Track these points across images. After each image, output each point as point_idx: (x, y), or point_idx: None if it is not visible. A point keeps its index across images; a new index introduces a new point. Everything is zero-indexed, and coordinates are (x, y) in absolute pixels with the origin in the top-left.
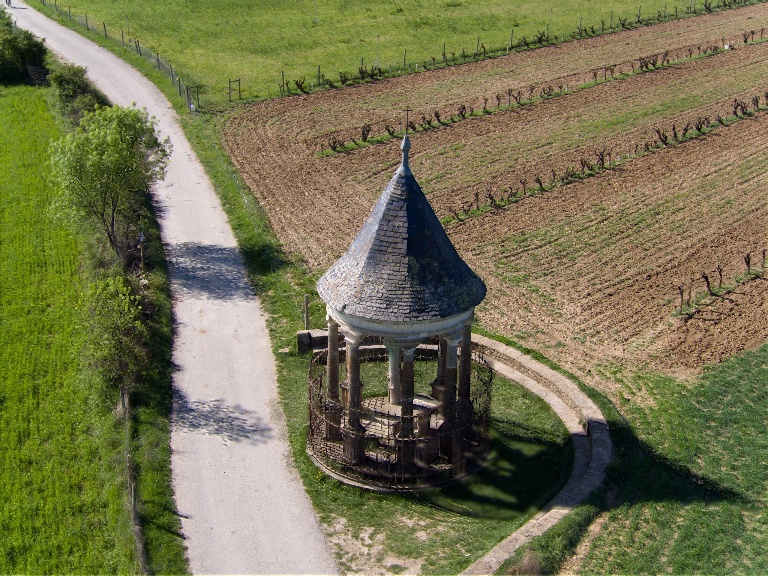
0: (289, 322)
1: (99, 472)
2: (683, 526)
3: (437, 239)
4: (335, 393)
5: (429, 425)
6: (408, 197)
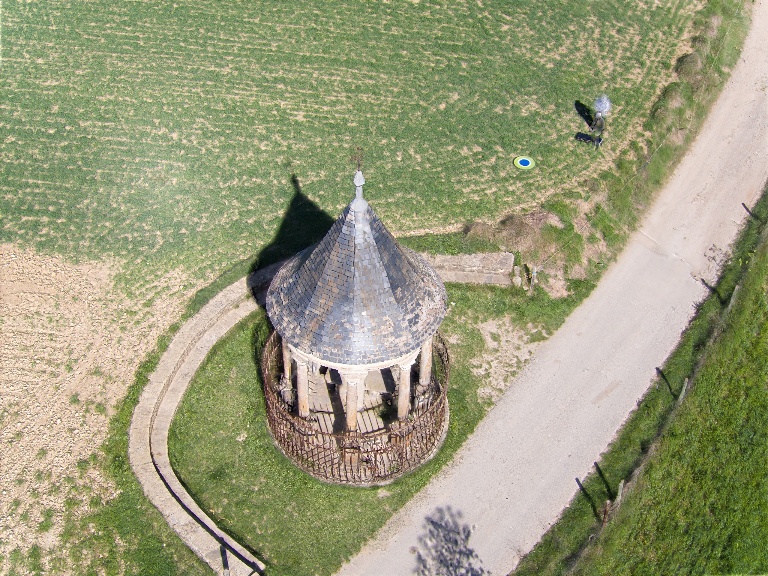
0: None
1: None
2: None
3: None
4: None
5: None
6: None
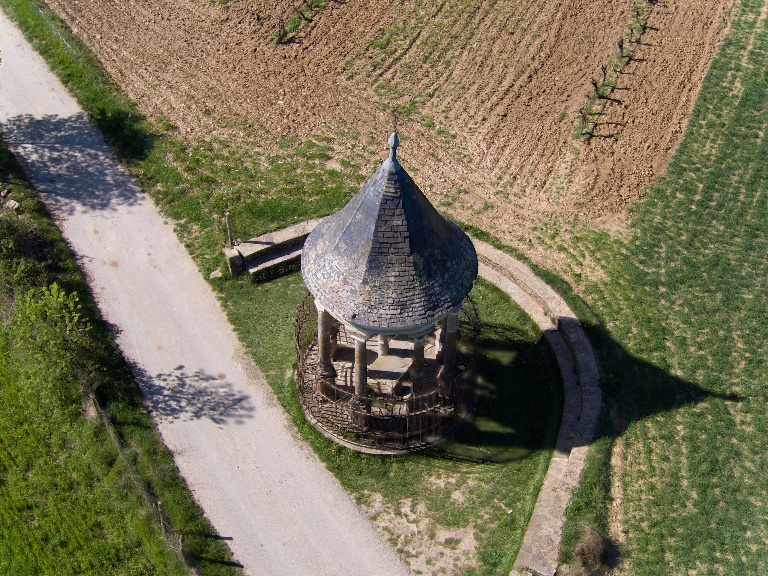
0: (202, 230)
1: (110, 501)
2: (687, 437)
3: (433, 224)
4: (328, 363)
5: None
6: (402, 193)
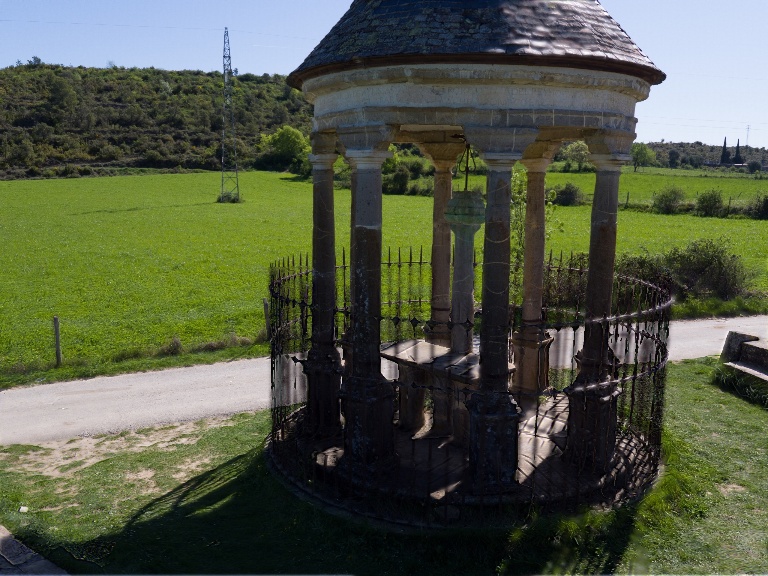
0: None
1: None
2: None
3: None
4: (434, 301)
5: (465, 423)
6: None
